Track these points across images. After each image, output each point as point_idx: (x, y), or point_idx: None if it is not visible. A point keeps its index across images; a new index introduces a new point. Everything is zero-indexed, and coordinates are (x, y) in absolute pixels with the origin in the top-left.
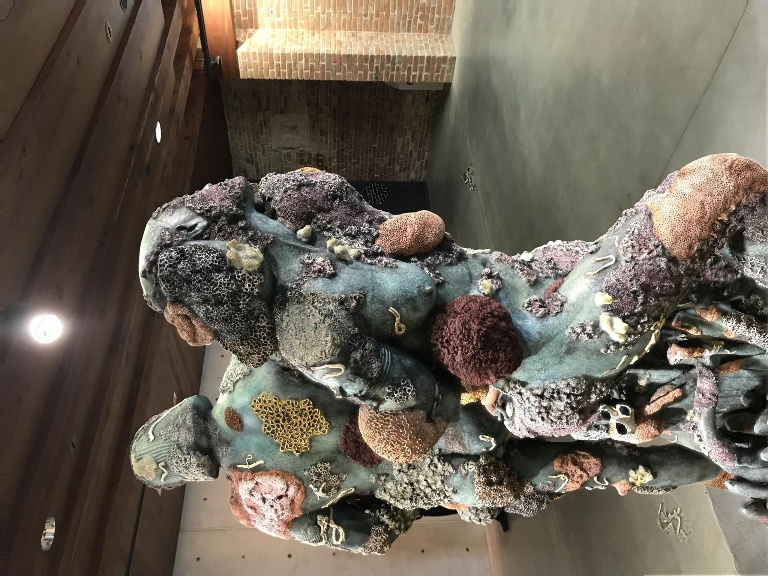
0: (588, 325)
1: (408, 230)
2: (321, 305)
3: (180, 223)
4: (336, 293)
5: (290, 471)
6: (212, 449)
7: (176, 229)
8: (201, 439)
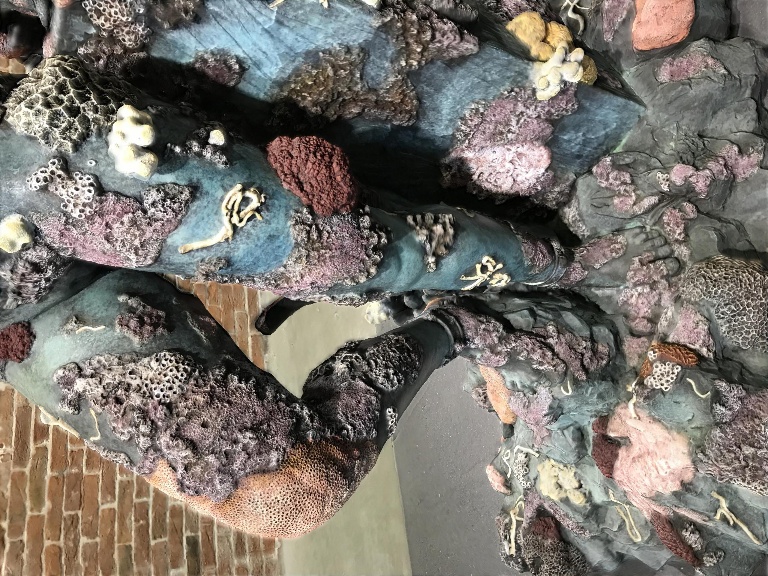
0: None
1: None
2: None
3: None
4: None
5: None
6: None
7: None
8: None
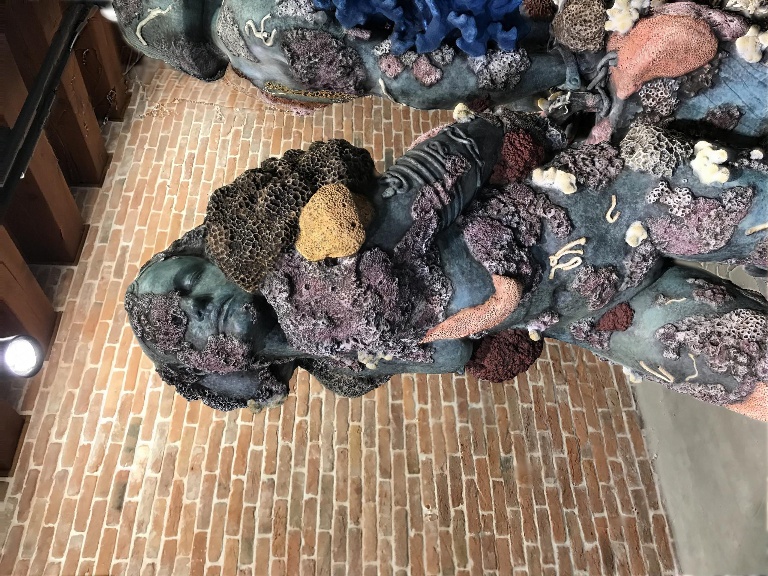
0: (611, 362)
1: (461, 336)
2: (347, 388)
3: (181, 364)
4: (363, 375)
5: (315, 101)
6: (222, 59)
7: (180, 369)
8: (208, 67)
